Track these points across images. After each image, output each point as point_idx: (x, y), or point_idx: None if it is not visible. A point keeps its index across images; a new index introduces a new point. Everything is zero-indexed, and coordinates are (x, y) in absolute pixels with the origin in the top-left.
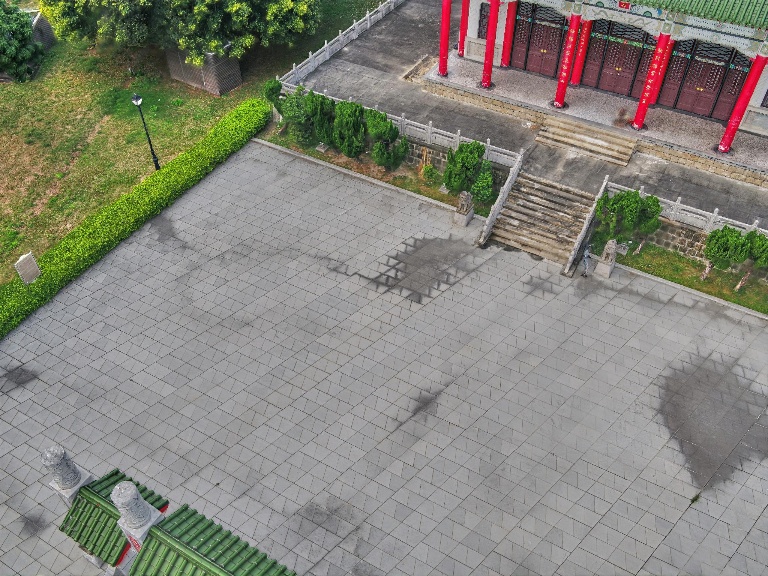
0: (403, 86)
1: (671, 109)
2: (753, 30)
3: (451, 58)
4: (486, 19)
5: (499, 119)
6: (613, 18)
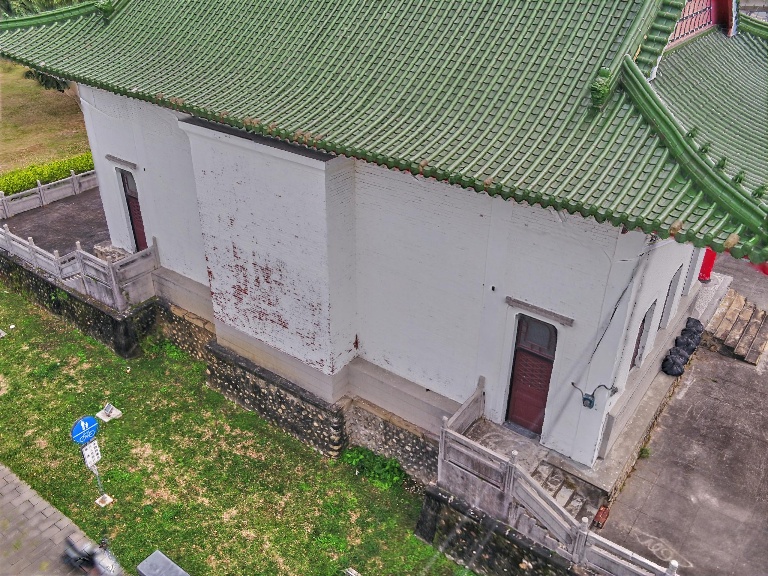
0: (765, 306)
1: None
2: None
3: (700, 305)
4: None
5: None
6: None
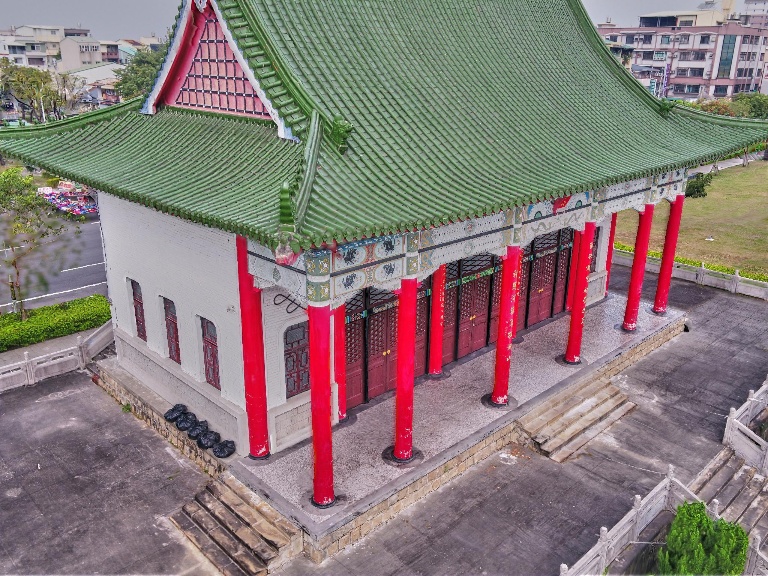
0: None
1: (528, 330)
2: (645, 179)
3: (262, 471)
4: (292, 356)
5: (481, 484)
6: (551, 228)
